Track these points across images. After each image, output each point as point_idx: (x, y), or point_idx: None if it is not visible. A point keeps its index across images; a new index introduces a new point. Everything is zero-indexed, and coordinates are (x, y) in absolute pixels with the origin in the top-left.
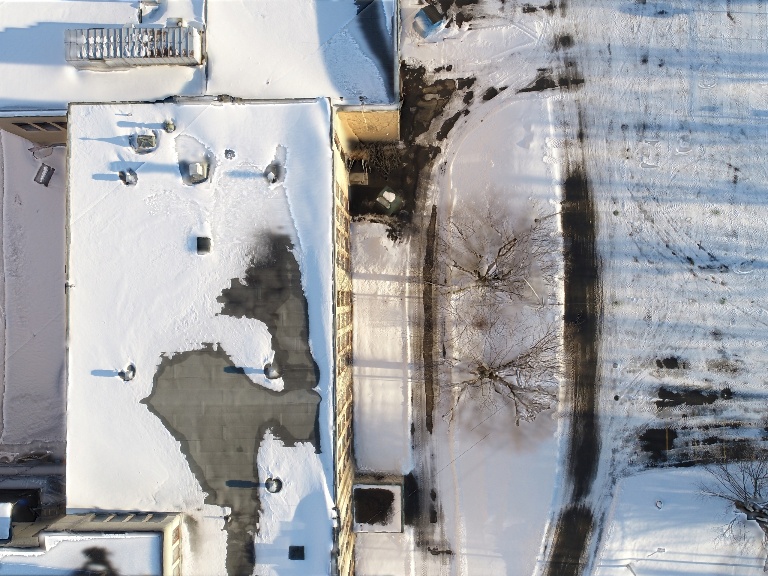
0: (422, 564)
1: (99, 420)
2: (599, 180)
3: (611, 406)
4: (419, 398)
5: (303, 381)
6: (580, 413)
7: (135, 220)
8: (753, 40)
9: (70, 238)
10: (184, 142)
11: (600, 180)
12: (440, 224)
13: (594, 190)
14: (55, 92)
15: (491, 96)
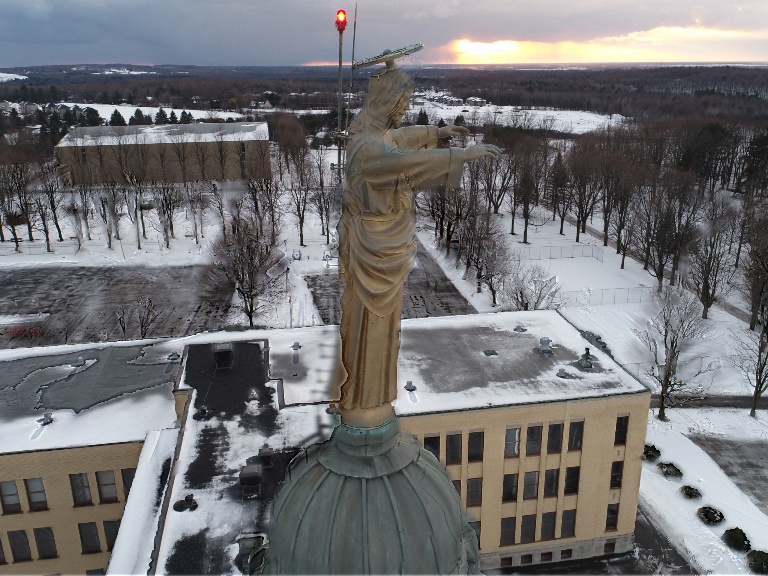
0: None
1: None
2: None
3: None
4: None
5: None
6: None
7: None
8: None
9: None
10: None
11: None
12: None
13: None
14: None
15: None
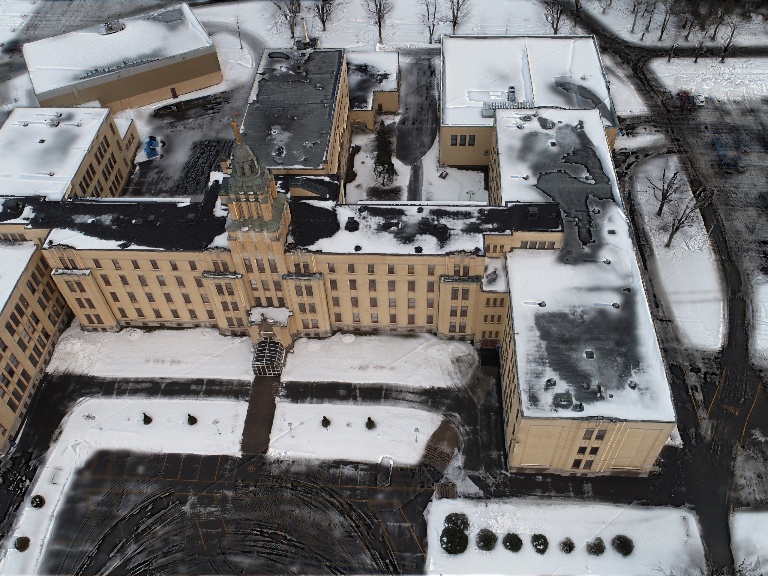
0: (656, 325)
1: (515, 190)
2: (706, 181)
3: (740, 258)
4: (638, 257)
5: (603, 181)
6: (725, 260)
7: (524, 138)
8: (761, 141)
9: (498, 141)
10: (542, 119)
11: (707, 181)
12: (634, 196)
13: (705, 184)
14: (475, 122)
15: (648, 156)
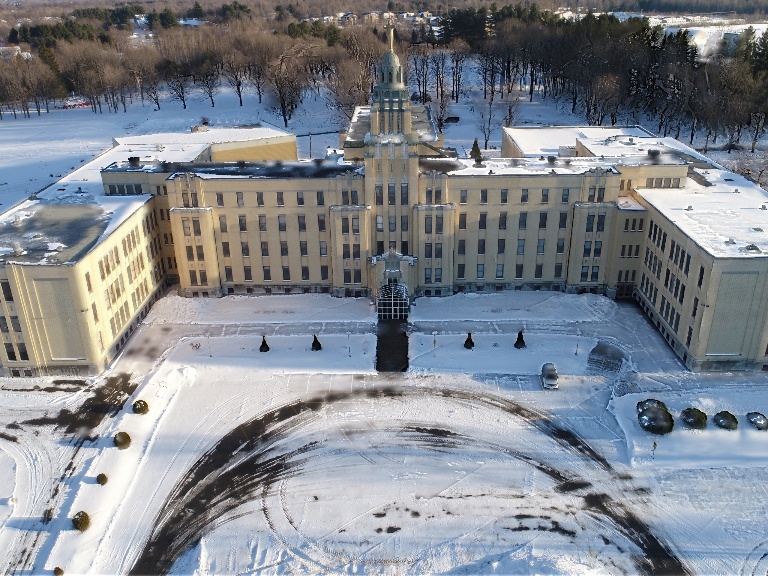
0: None
1: None
2: None
3: None
4: None
5: None
6: None
7: None
8: None
9: (589, 149)
10: None
11: None
12: None
13: None
14: None
15: None
